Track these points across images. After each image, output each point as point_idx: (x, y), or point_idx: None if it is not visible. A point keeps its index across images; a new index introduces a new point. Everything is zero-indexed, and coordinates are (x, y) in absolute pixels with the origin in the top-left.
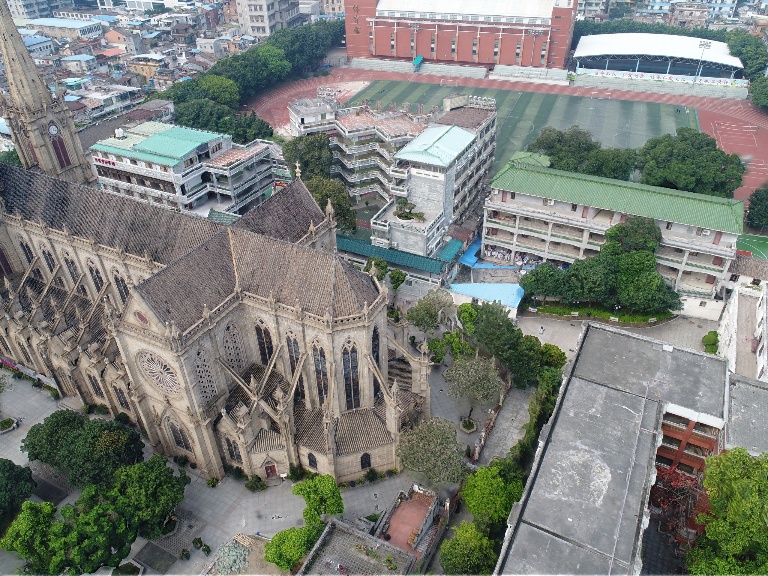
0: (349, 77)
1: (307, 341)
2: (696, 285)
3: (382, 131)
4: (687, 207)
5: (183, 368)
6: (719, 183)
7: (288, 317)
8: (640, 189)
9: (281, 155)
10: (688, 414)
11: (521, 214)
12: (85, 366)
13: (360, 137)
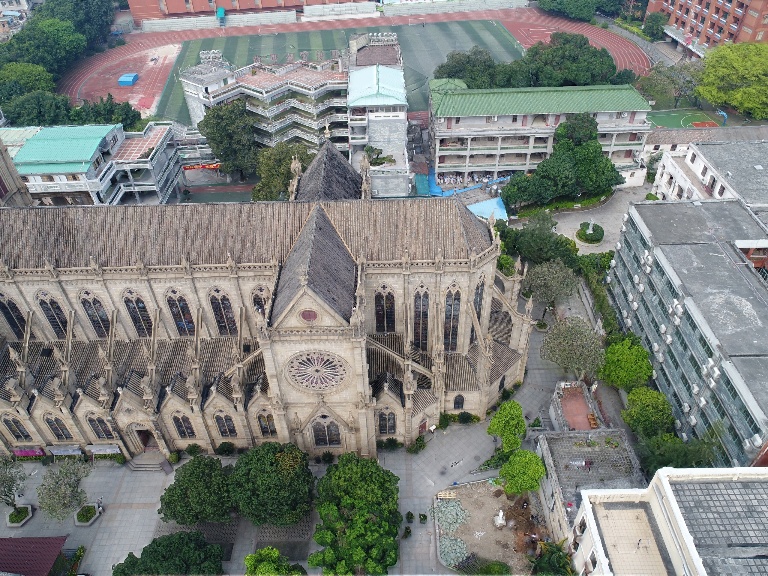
0: (152, 42)
1: (441, 290)
2: (620, 161)
3: (302, 85)
4: (603, 97)
5: (361, 353)
6: (604, 74)
7: (425, 271)
8: (561, 90)
9: (188, 134)
10: (749, 244)
11: (473, 135)
12: (173, 408)
13: (273, 96)
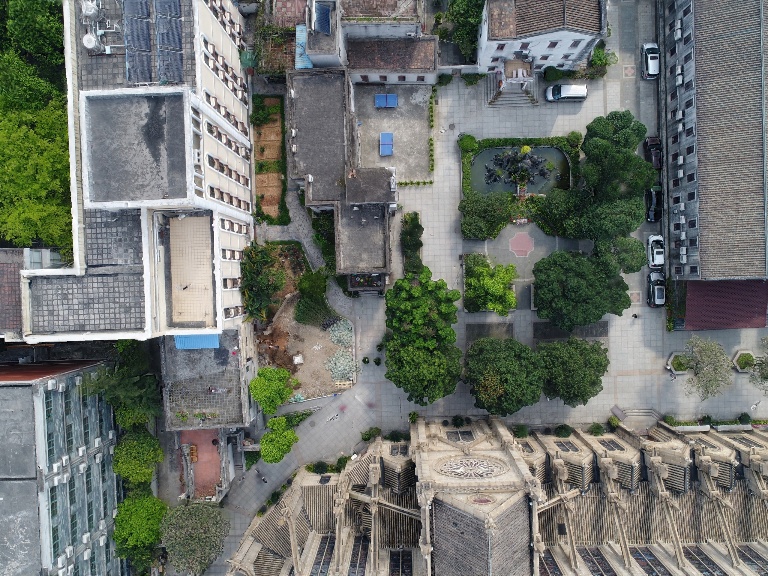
0: None
1: None
2: None
3: None
4: None
5: None
6: None
7: None
8: None
9: None
10: None
11: None
12: (627, 454)
13: None
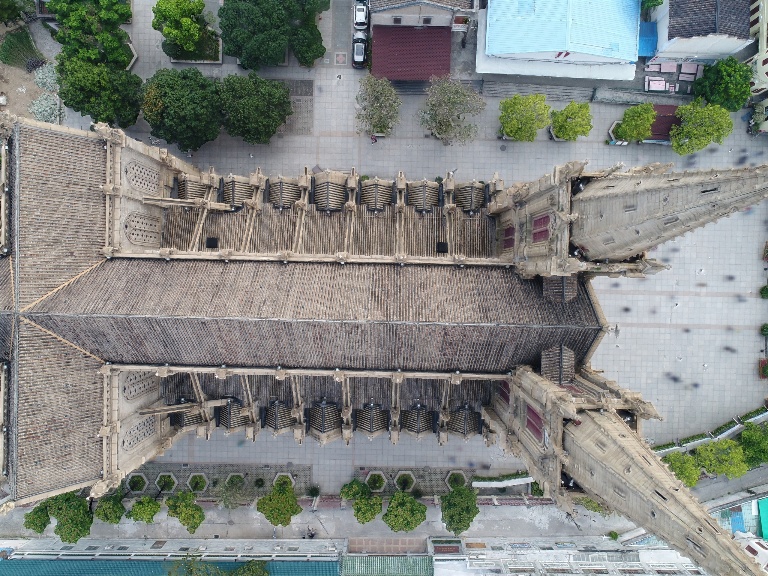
0: None
1: None
2: None
3: None
4: None
5: None
6: None
7: None
8: None
9: None
10: None
11: None
12: None
13: None
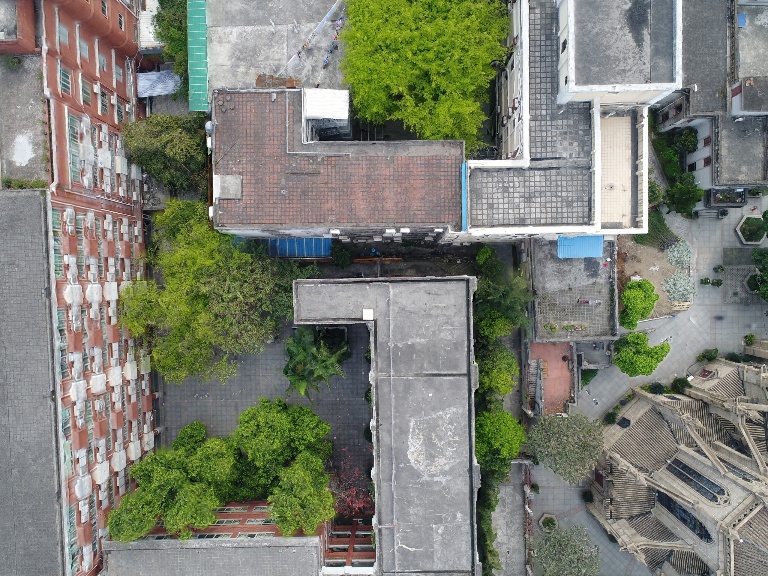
0: None
1: None
2: None
3: None
4: None
5: None
6: None
7: None
8: None
9: None
10: (354, 570)
11: None
12: None
13: None
